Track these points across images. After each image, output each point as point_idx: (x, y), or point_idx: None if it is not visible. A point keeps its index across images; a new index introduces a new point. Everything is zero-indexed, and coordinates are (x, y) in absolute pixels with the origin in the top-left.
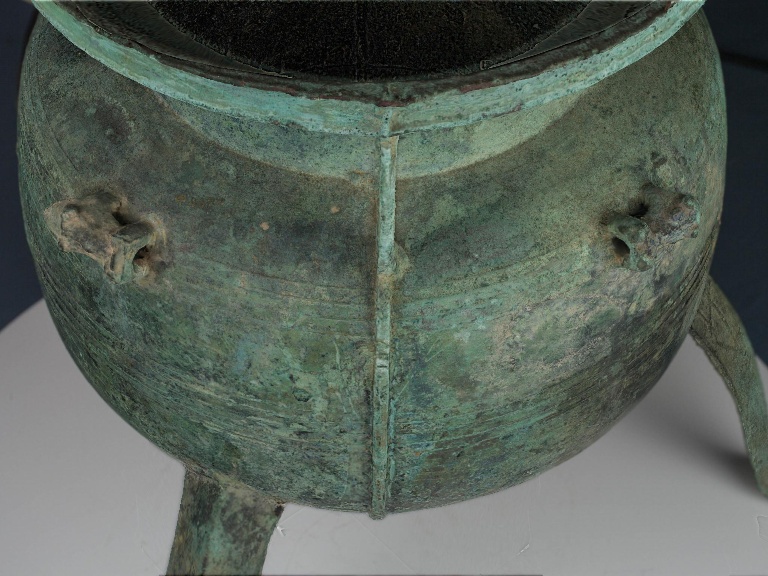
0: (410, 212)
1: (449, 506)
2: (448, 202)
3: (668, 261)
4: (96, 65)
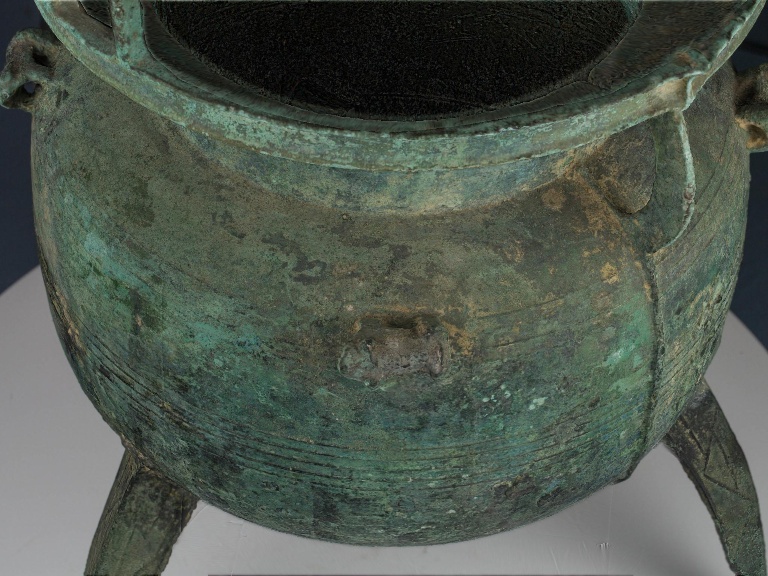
0: None
1: (324, 573)
2: None
3: None
4: None
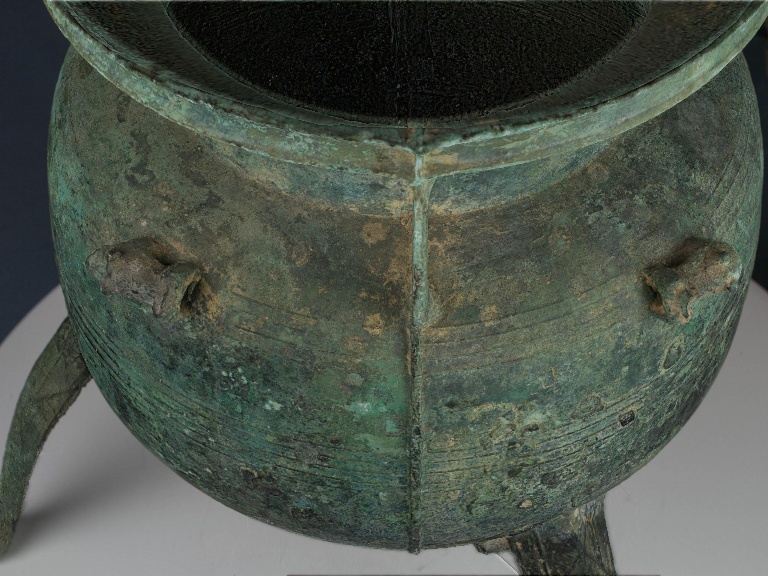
0: None
1: None
2: None
3: None
4: None
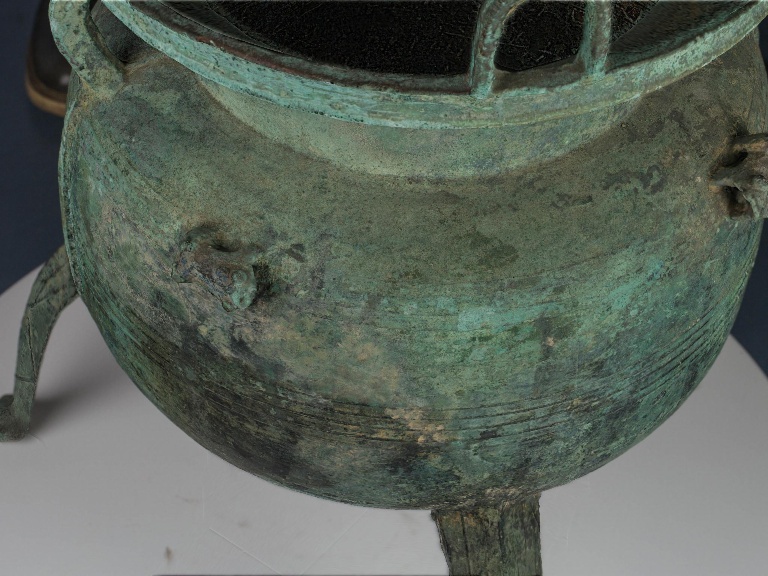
0: (157, 77)
1: (414, 568)
2: (173, 98)
3: (253, 337)
4: None
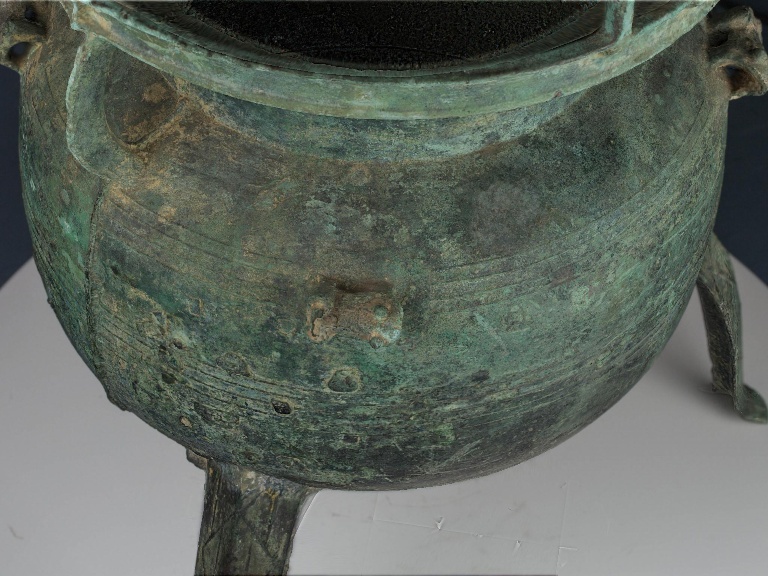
0: None
1: None
2: None
3: None
4: (617, 116)
